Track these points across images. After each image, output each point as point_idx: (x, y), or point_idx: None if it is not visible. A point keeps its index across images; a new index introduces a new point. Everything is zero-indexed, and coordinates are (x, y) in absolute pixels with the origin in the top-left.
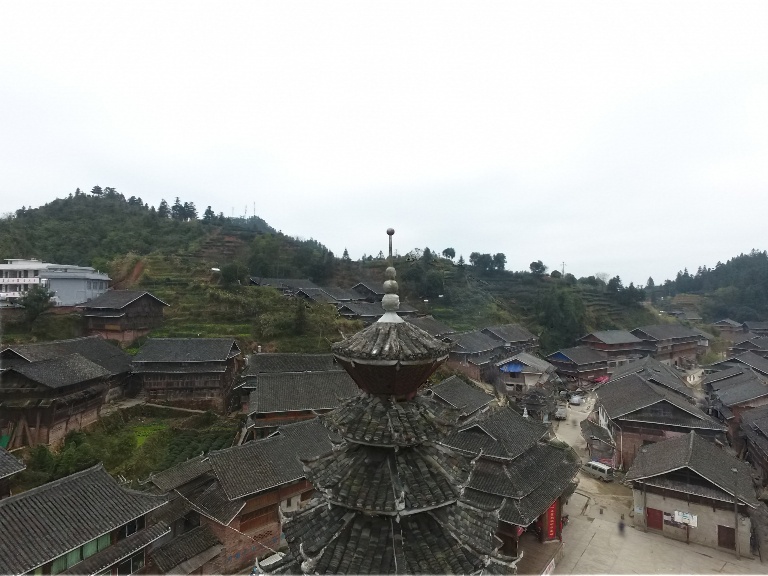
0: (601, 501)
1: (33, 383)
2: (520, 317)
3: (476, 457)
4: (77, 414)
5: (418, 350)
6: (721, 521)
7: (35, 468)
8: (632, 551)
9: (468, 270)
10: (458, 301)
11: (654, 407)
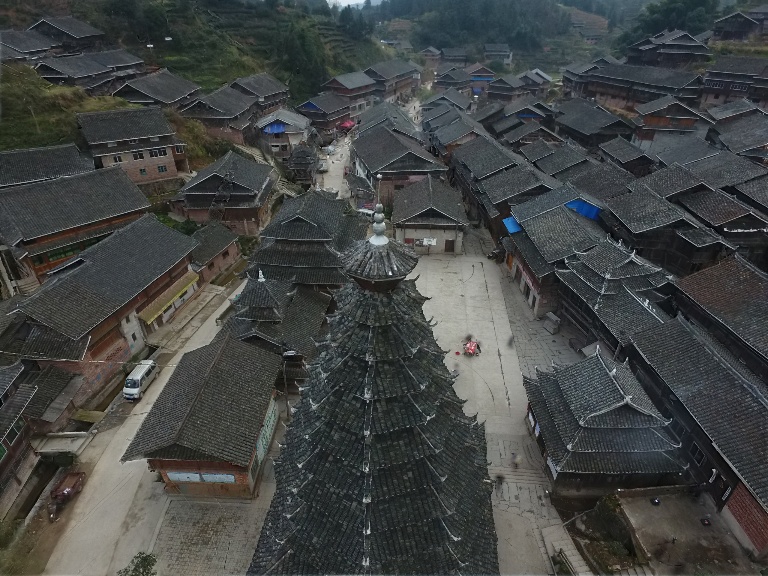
0: None
1: None
2: (264, 62)
3: None
4: None
5: None
6: (448, 237)
7: None
8: None
9: (194, 0)
10: (191, 45)
11: (402, 158)
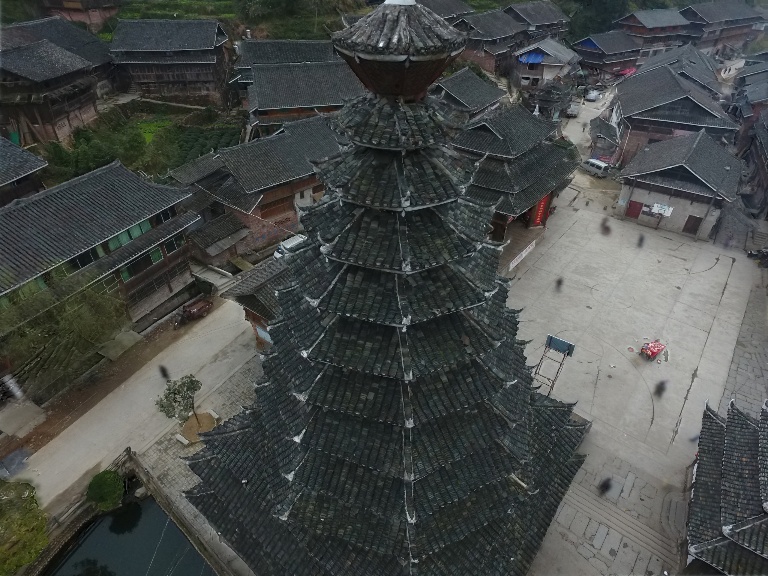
0: (590, 195)
1: (13, 76)
2: None
3: (481, 159)
4: (74, 110)
5: (431, 42)
6: (694, 212)
7: (57, 163)
8: (605, 235)
9: None
10: None
11: (673, 104)
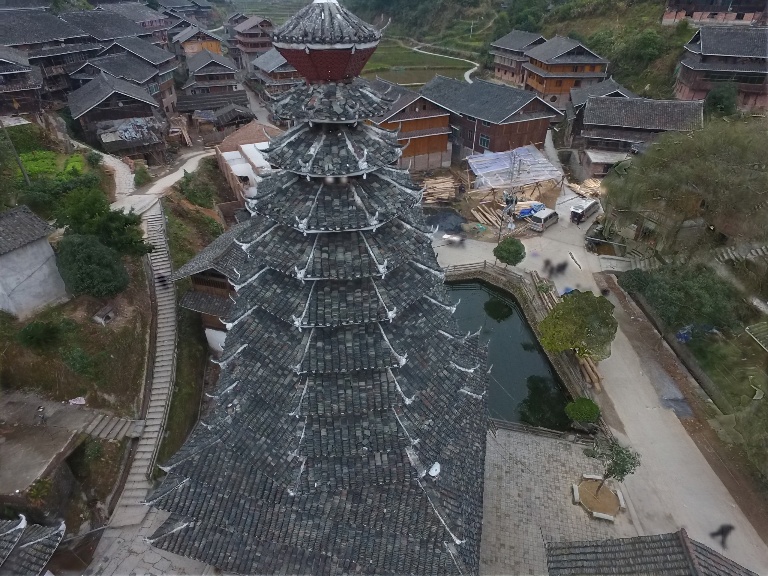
0: None
1: None
2: None
3: (261, 150)
4: None
5: None
6: None
7: None
8: None
9: None
10: None
11: None
